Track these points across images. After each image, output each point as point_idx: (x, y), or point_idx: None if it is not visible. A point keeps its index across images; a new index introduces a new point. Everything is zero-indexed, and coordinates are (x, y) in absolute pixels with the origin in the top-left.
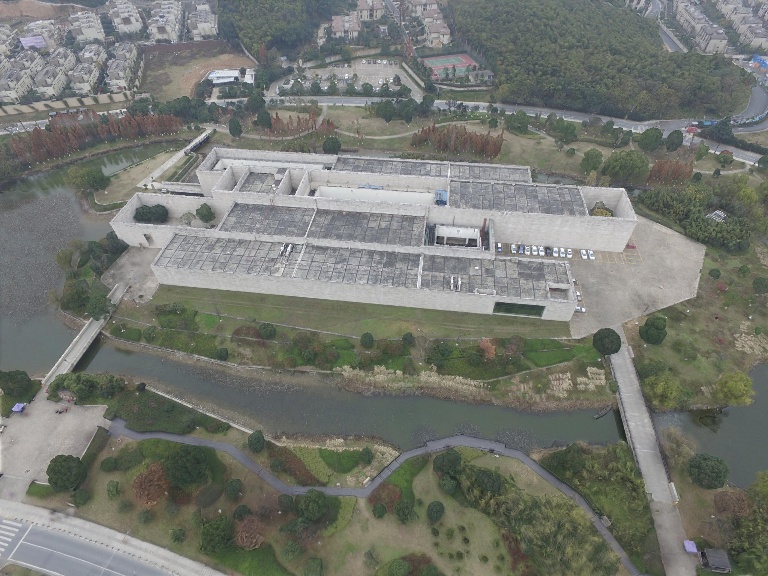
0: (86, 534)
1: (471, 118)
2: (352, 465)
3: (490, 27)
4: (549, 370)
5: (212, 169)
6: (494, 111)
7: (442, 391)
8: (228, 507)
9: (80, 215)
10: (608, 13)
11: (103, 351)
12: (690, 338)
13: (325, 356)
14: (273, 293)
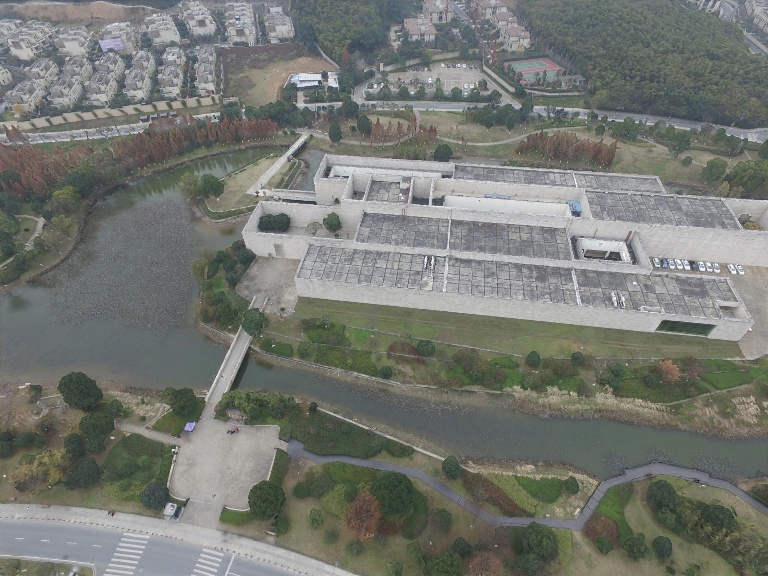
0: (293, 565)
1: (571, 124)
2: (556, 494)
3: (573, 31)
4: (730, 393)
5: (328, 176)
6: (594, 117)
7: (623, 414)
8: (437, 539)
9: (194, 223)
10: (693, 17)
11: (254, 367)
12: None
13: (492, 375)
14: (419, 307)
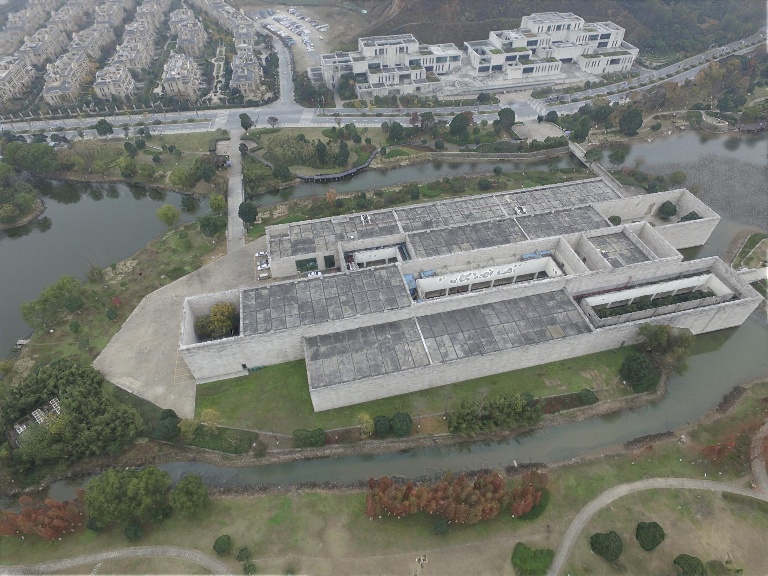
0: None
1: None
2: (389, 153)
3: None
4: (288, 216)
5: None
6: None
7: (356, 193)
8: None
9: None
10: None
11: None
12: (173, 257)
13: None
14: None
